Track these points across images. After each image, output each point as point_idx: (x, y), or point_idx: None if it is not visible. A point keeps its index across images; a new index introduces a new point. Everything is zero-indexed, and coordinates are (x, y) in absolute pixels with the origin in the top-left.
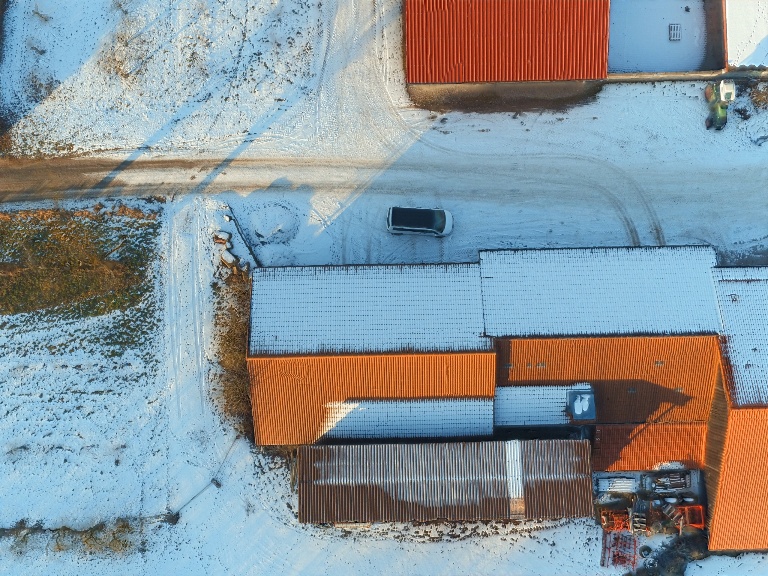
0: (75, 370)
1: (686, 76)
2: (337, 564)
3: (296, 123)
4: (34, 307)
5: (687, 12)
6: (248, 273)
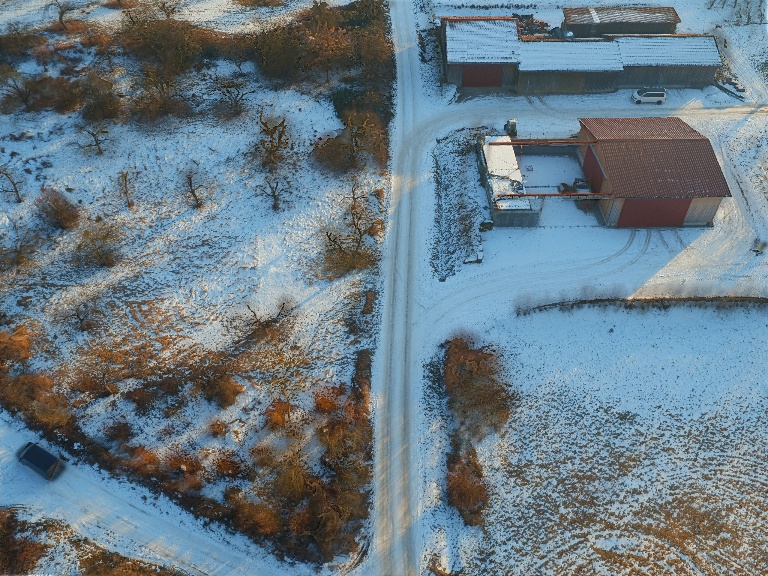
0: None
1: None
2: None
3: None
4: None
5: None
6: None
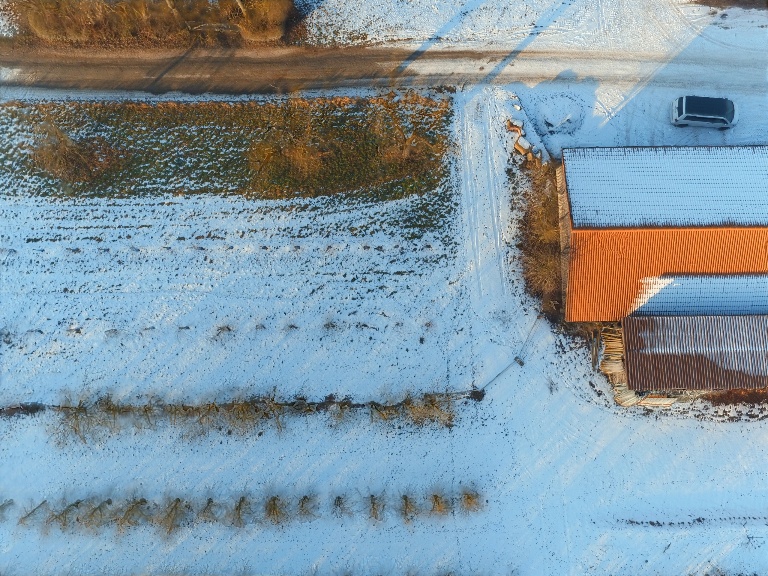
0: (377, 251)
1: None
2: (640, 441)
3: (580, 17)
4: (334, 190)
5: None
6: (541, 160)
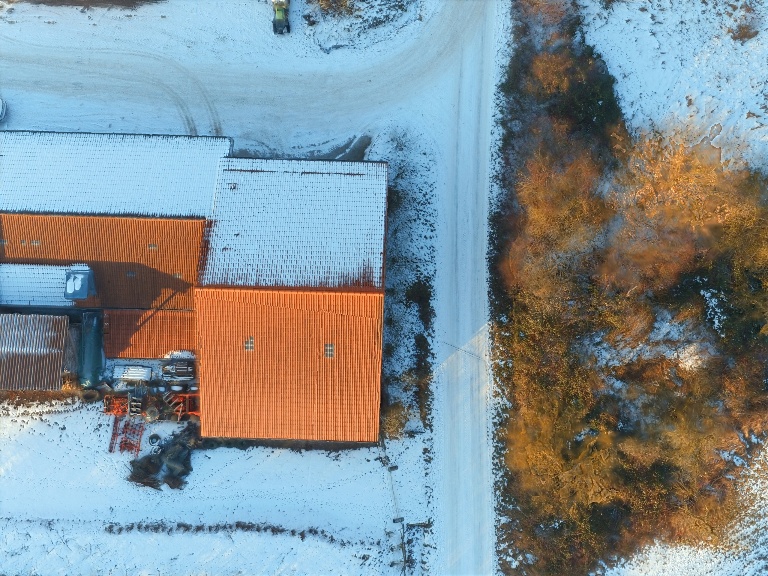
0: None
1: None
2: None
3: None
4: None
5: None
6: None
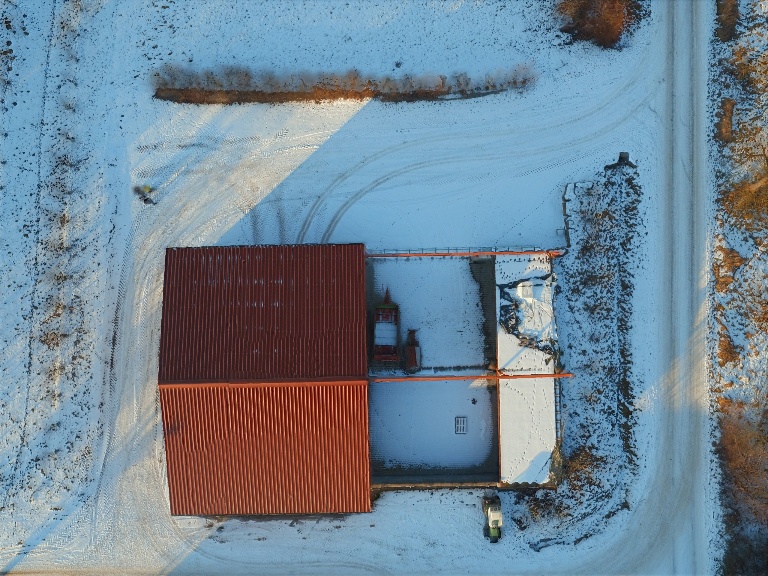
0: None
1: None
2: None
3: (71, 533)
4: None
5: (473, 405)
6: None
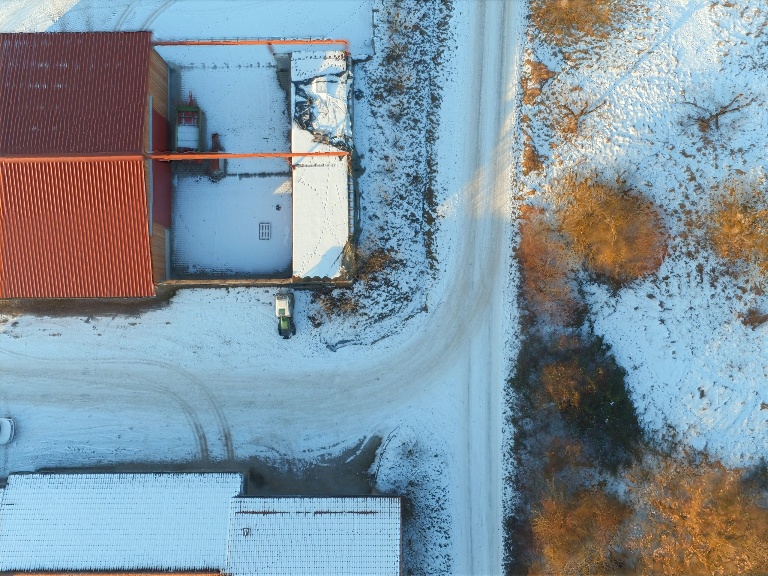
0: None
1: (258, 283)
2: None
3: None
4: None
5: (278, 211)
6: None
